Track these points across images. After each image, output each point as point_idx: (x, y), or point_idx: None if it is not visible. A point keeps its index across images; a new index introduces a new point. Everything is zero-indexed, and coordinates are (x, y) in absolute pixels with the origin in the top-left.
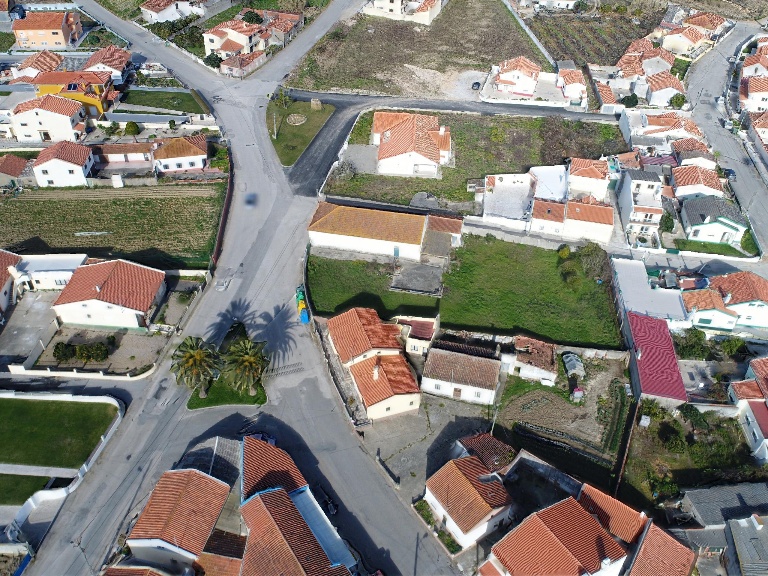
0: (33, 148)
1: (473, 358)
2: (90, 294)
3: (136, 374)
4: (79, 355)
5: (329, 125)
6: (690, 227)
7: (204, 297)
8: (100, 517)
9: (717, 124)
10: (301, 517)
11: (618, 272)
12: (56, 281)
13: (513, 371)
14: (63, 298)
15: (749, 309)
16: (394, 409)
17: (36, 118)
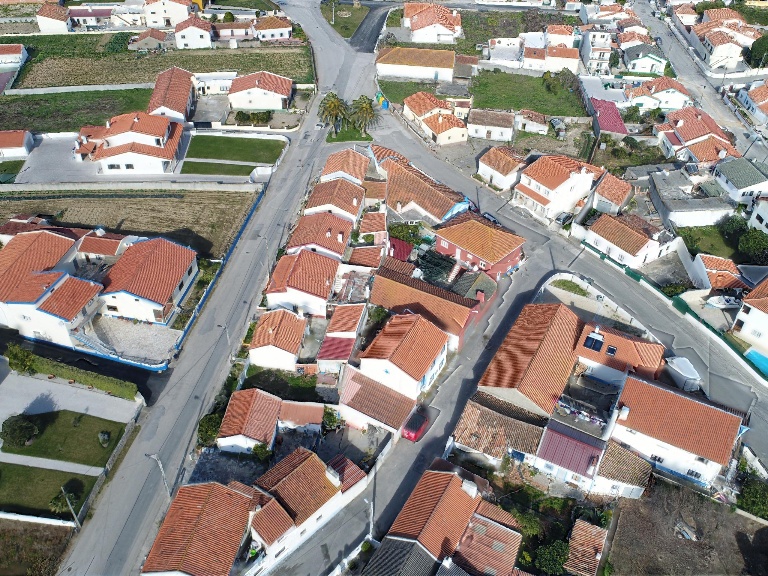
0: (161, 30)
1: (498, 113)
2: (252, 86)
3: (290, 128)
4: (252, 118)
5: (369, 17)
6: (630, 63)
7: (316, 99)
8: (295, 181)
9: (650, 15)
10: (414, 168)
11: (583, 82)
12: (220, 87)
13: (521, 127)
14: (233, 91)
15: (666, 95)
16: (453, 139)
17: (163, 7)
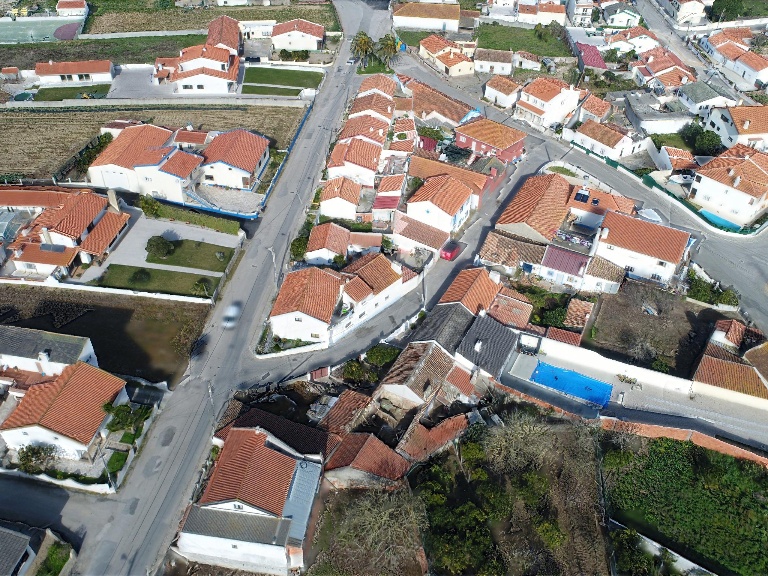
0: None
1: (499, 51)
2: (292, 30)
3: (325, 64)
4: (294, 55)
5: None
6: (609, 18)
7: (343, 44)
8: (335, 100)
9: None
10: None
11: (570, 32)
12: (263, 33)
13: (518, 65)
14: (275, 34)
15: (640, 41)
16: (462, 71)
17: None
